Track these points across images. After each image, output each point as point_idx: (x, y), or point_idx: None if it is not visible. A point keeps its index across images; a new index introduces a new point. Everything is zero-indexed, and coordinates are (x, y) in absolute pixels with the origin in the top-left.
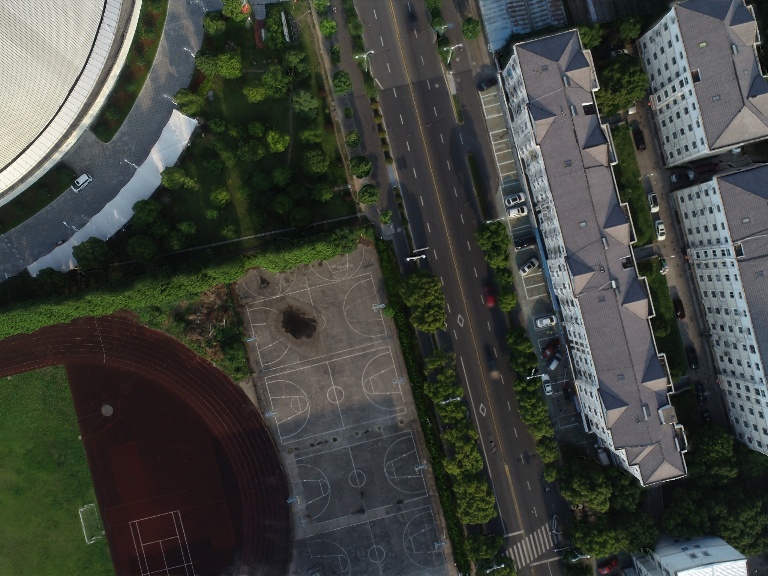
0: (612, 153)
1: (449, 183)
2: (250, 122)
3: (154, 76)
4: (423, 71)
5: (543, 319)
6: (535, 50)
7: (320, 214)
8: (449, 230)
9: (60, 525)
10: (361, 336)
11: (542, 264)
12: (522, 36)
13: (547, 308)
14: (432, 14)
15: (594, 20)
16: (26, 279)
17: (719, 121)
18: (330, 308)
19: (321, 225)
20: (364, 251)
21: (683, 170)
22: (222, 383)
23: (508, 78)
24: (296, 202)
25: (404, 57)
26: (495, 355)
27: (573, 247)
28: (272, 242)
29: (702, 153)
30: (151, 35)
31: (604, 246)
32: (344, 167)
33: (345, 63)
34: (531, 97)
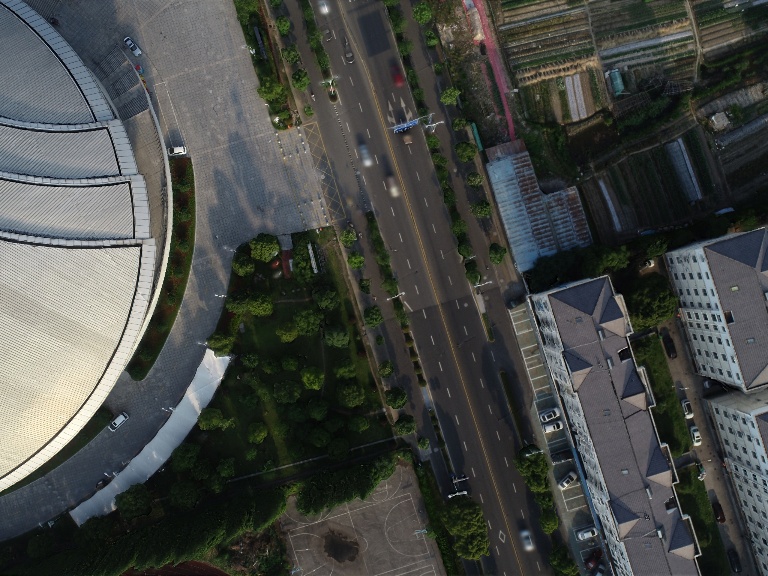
0: (649, 395)
1: (483, 401)
2: (283, 357)
3: (184, 311)
4: (451, 291)
5: (584, 533)
6: (568, 300)
7: (357, 439)
8: (486, 449)
9: None
10: (404, 556)
11: (580, 477)
12: (550, 264)
13: (587, 519)
14: (458, 239)
15: (618, 230)
16: (68, 519)
17: (755, 363)
18: (371, 530)
19: (358, 450)
20: (402, 472)
21: (716, 381)
22: None
23: (539, 307)
24: (333, 433)
25: (432, 280)
26: (538, 569)
27: (616, 492)
28: (310, 469)
29: (738, 386)
30: (180, 275)
31: (648, 496)
32: (378, 391)
33: (374, 292)
34: (566, 345)
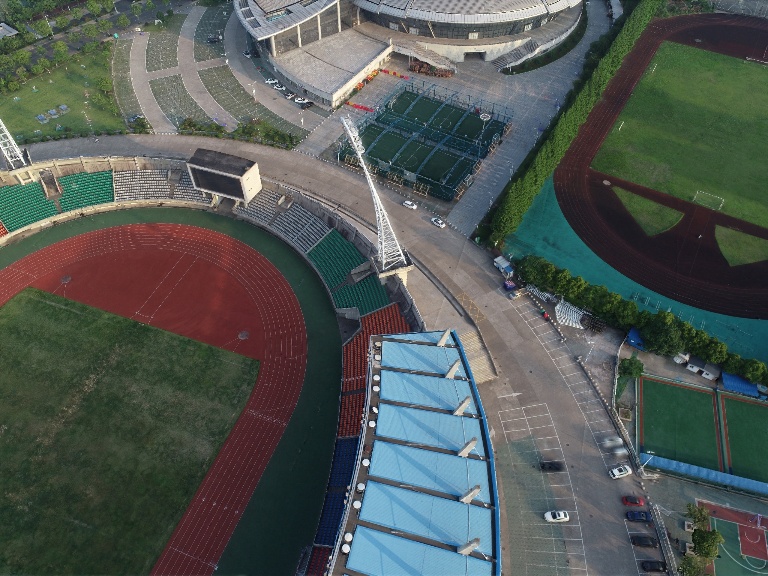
0: None
1: None
2: None
3: None
4: None
5: None
6: None
7: None
8: None
9: (749, 73)
10: None
11: None
12: None
13: None
14: None
15: None
16: None
17: None
18: None
19: None
20: None
21: None
22: (711, 15)
23: None
24: None
25: None
26: None
27: None
28: None
29: None
30: None
31: None
32: None
33: None
34: None
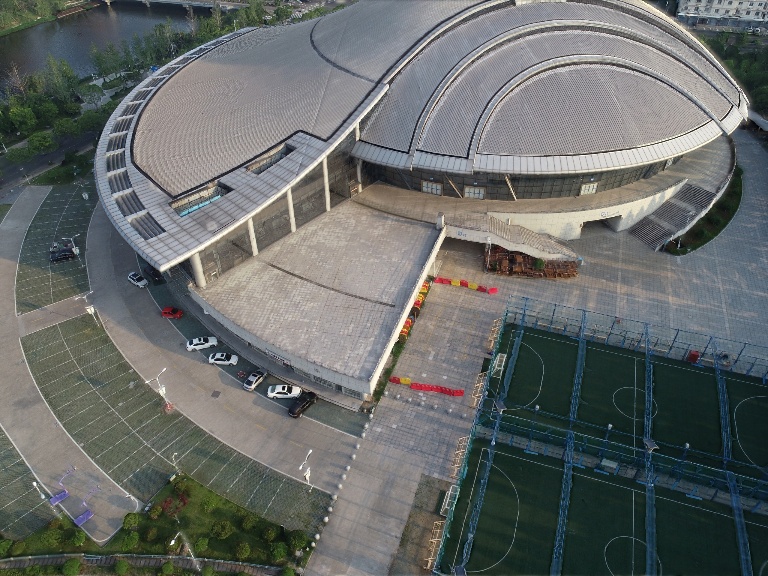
0: None
1: None
2: None
3: None
4: None
5: None
6: None
7: None
8: (764, 42)
9: None
10: None
11: None
12: None
13: None
14: None
15: None
16: None
17: None
18: None
19: None
20: None
21: None
22: None
23: (686, 5)
24: None
25: None
26: None
27: None
28: None
29: None
30: None
31: None
32: None
33: None
34: None
